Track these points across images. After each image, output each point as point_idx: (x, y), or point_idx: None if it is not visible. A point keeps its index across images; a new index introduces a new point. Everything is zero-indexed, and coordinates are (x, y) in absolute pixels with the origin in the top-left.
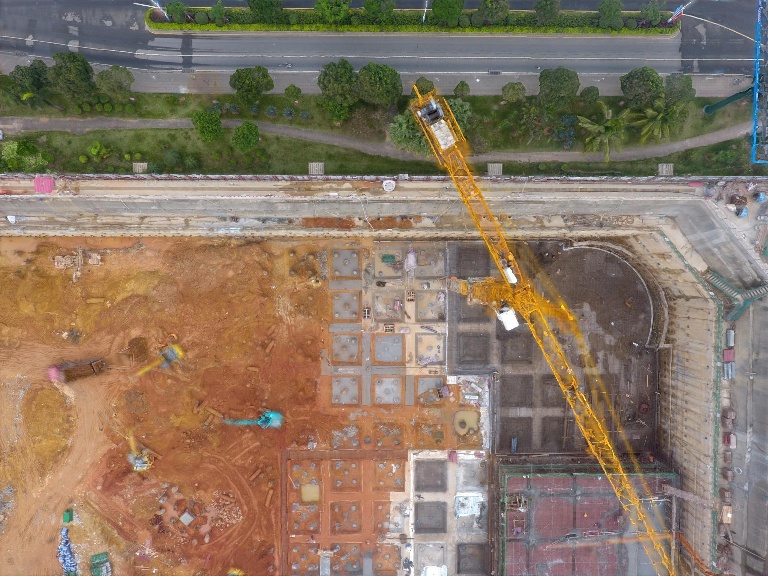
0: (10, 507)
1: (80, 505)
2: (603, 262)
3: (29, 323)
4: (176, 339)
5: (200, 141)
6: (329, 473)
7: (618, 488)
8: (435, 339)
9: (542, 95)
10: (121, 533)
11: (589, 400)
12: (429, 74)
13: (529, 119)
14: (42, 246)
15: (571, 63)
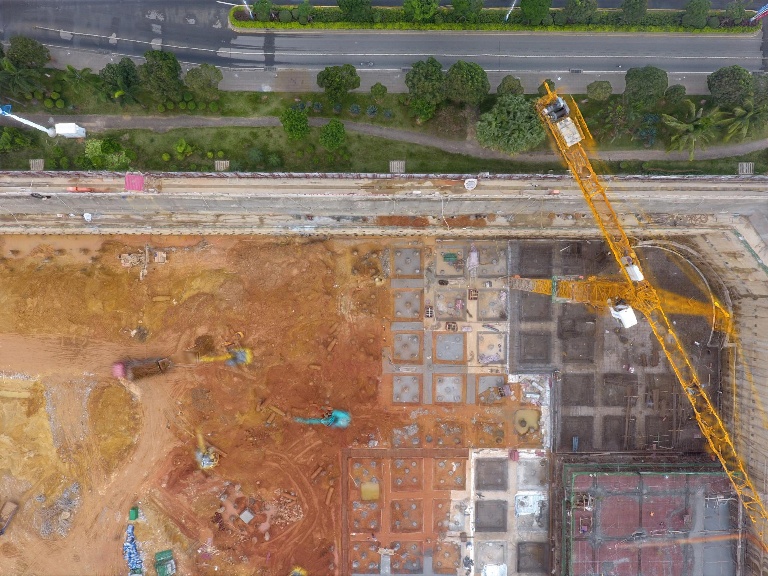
0: (76, 504)
1: (145, 503)
2: (665, 261)
3: (96, 321)
4: (242, 337)
5: (283, 139)
6: (390, 471)
7: (738, 486)
8: (496, 338)
9: (629, 93)
10: (184, 531)
11: (651, 399)
12: (510, 72)
13: (615, 117)
14: (108, 244)
15: (652, 62)
